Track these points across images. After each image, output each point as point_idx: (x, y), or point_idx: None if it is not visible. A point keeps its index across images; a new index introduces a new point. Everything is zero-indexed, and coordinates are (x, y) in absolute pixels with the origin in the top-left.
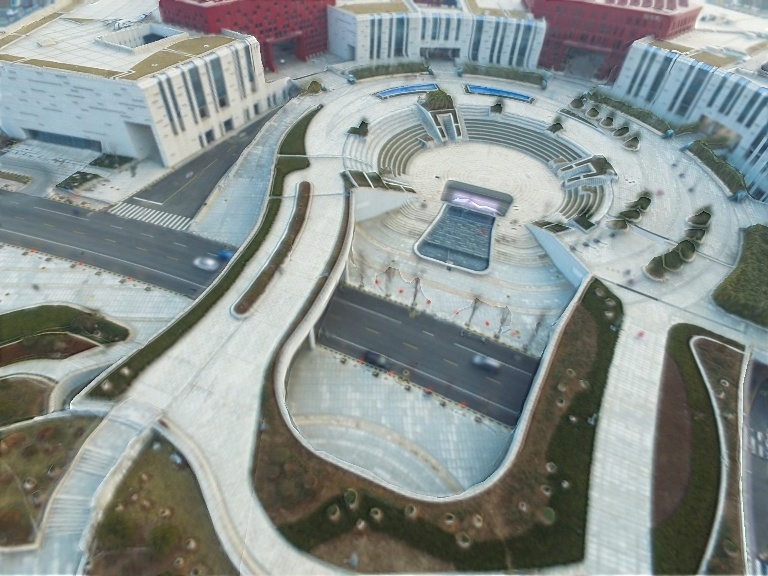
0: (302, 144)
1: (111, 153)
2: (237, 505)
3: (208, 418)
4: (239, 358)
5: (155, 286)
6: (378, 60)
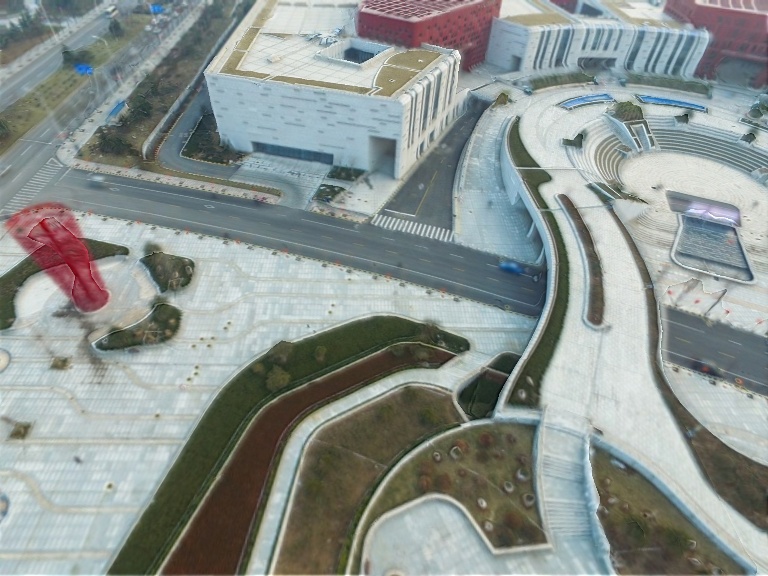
0: (529, 156)
1: (347, 166)
2: (712, 509)
3: (631, 426)
4: (622, 368)
5: (461, 297)
6: (541, 70)
